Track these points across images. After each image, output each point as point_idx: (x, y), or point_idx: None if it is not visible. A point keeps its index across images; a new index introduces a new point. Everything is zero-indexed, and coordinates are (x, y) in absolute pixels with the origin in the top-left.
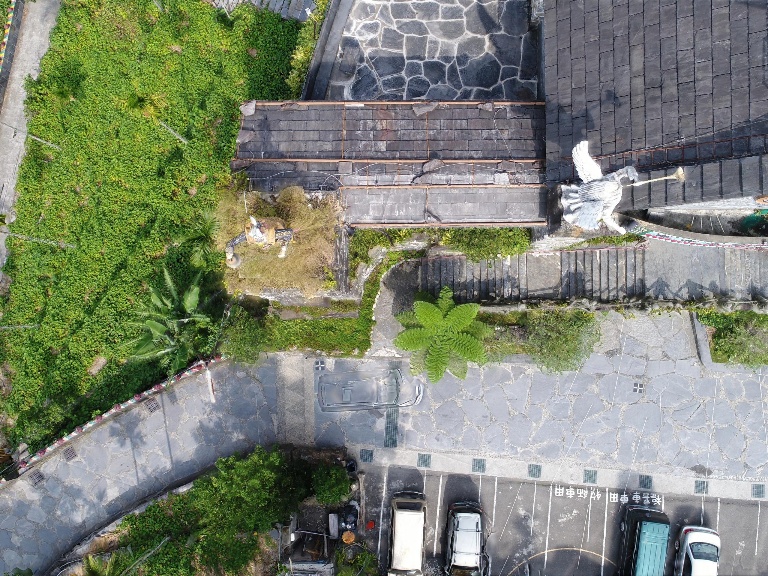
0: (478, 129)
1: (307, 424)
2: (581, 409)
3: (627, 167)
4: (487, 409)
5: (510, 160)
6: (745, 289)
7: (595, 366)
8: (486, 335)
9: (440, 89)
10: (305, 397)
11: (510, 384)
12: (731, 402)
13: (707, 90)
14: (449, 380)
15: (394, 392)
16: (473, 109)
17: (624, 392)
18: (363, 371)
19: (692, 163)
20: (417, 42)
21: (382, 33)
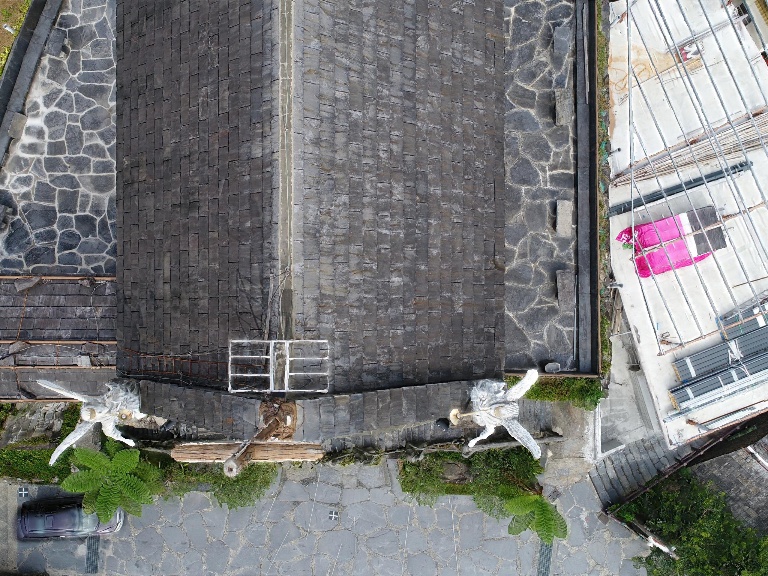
0: (74, 306)
1: (10, 550)
2: (278, 536)
3: (113, 391)
4: (186, 536)
5: (94, 342)
6: (398, 436)
7: (292, 494)
8: (154, 477)
9: (91, 242)
10: (8, 523)
11: (209, 511)
12: (423, 530)
13: (205, 310)
14: (149, 507)
15: (95, 519)
16: (74, 284)
17: (320, 519)
18: (65, 498)
19: (189, 382)
20: (69, 196)
21: (35, 186)
